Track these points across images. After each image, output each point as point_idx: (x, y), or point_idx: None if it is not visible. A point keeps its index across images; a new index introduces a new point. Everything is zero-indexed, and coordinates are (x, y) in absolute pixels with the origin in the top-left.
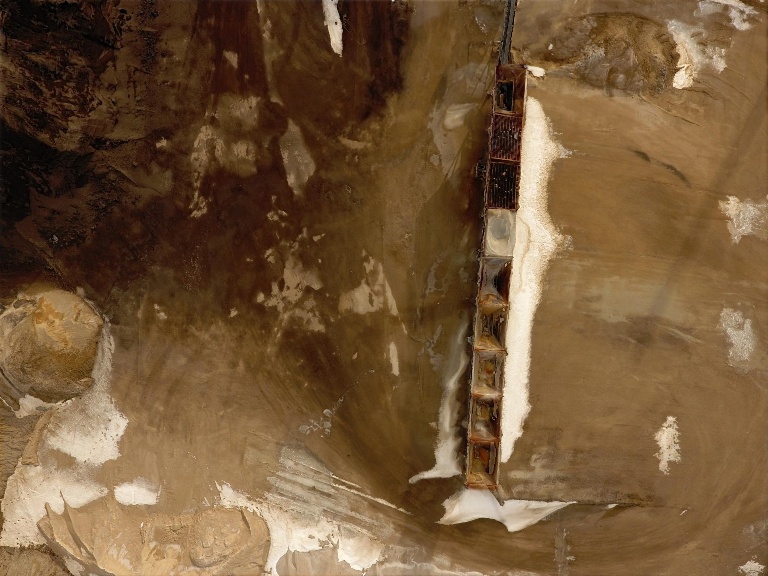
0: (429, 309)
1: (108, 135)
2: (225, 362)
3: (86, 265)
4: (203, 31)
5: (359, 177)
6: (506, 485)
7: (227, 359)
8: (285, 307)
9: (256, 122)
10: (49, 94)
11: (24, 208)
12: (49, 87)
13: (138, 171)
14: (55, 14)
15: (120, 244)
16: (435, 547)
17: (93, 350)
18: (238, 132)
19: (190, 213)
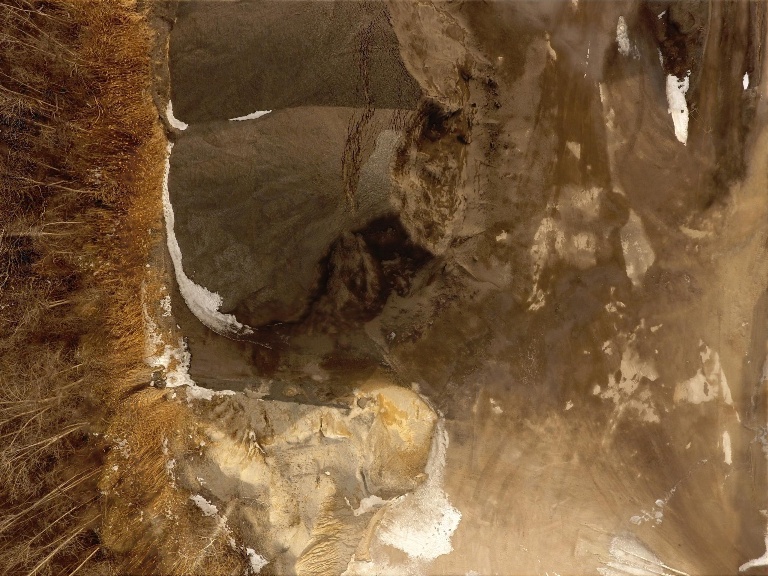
0: (763, 397)
1: (460, 233)
2: (559, 455)
3: (422, 360)
4: (546, 122)
5: (699, 266)
6: None
7: (562, 452)
8: (621, 399)
9: (597, 213)
10: (433, 201)
11: (378, 309)
12: (433, 194)
13: (478, 265)
14: (447, 121)
15: (456, 339)
16: None
17: (428, 446)
18: (579, 224)
19: (528, 306)
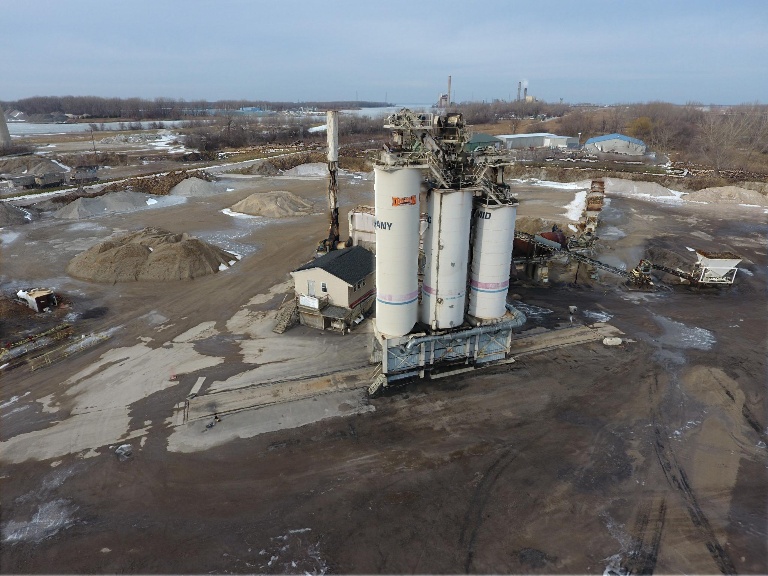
0: None
1: None
2: None
3: None
4: None
5: None
6: None
7: None
8: None
9: None
10: None
11: None
12: None
13: None
14: None
15: None
16: None
17: None
18: None
19: None
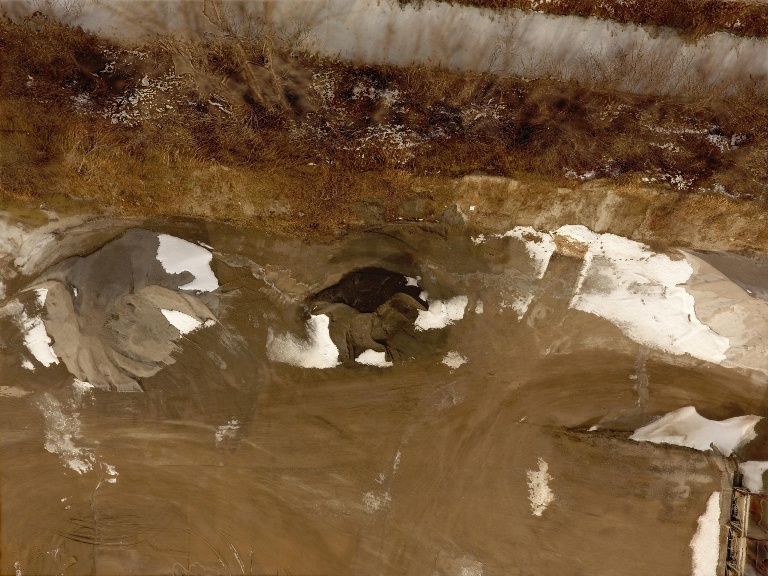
0: None
1: None
2: None
3: None
4: None
5: None
6: (714, 469)
7: None
8: None
9: None
10: None
11: None
12: None
13: None
14: None
15: None
16: (765, 393)
17: None
18: None
19: None
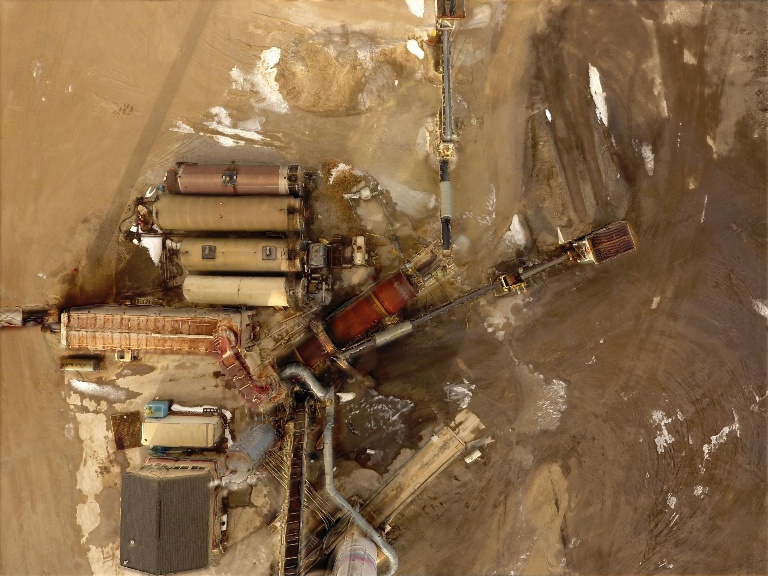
0: None
1: None
2: None
3: None
4: (715, 81)
5: None
6: None
7: None
8: None
9: (666, 1)
10: None
11: None
12: None
13: None
14: None
15: None
16: None
17: None
18: None
19: None
